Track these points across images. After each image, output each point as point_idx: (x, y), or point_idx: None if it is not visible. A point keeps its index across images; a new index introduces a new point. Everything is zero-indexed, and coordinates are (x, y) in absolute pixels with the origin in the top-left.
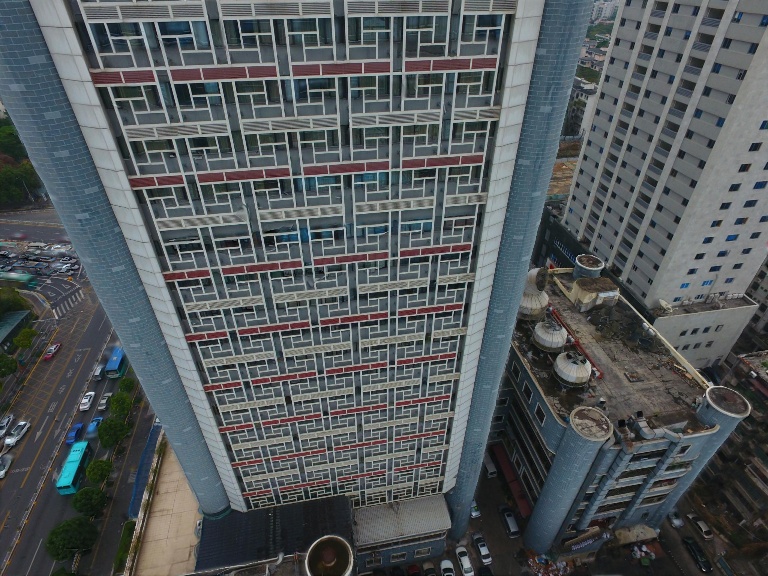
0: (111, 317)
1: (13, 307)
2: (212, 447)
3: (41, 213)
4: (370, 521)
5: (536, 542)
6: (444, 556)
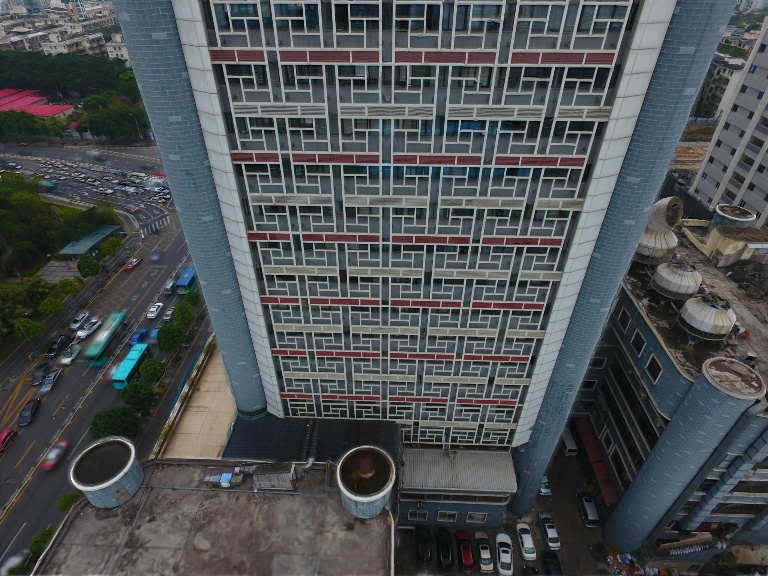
0: (149, 111)
1: (107, 221)
2: (252, 324)
3: (147, 150)
4: (420, 465)
5: (621, 536)
6: (501, 529)
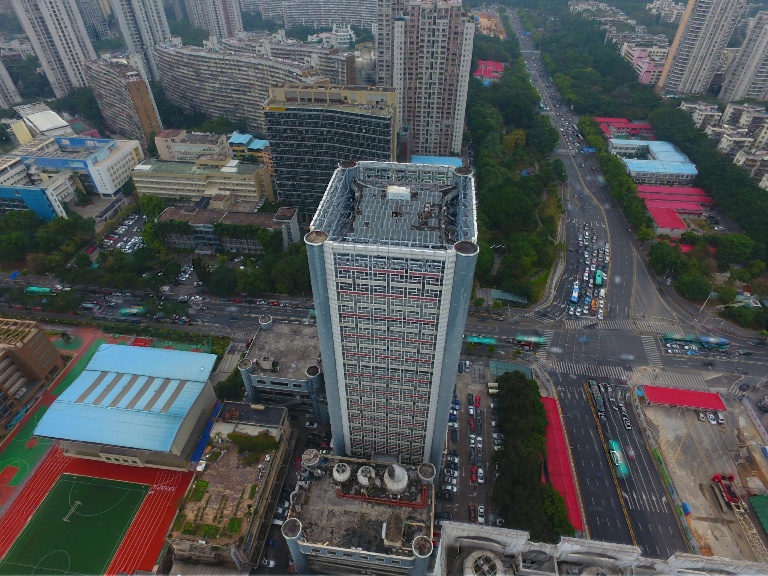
0: None
1: (529, 296)
2: None
3: (652, 286)
4: None
5: None
6: None
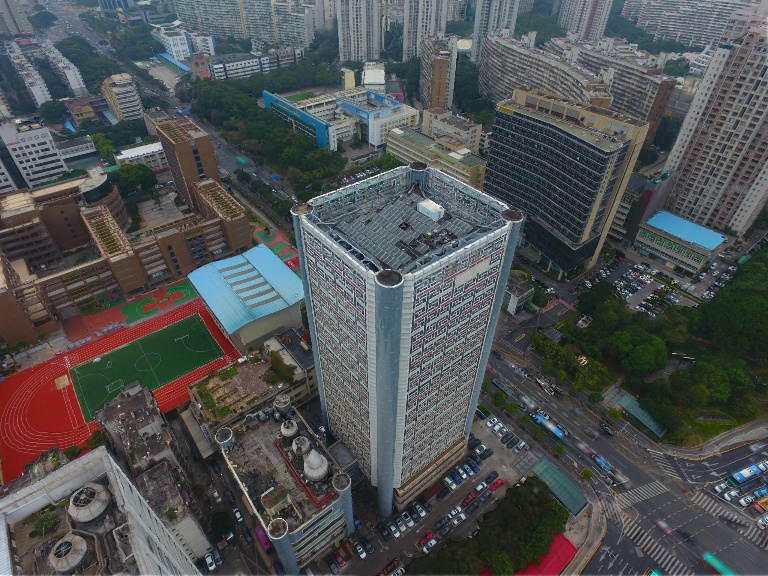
0: None
1: None
2: None
3: None
4: None
5: None
6: None
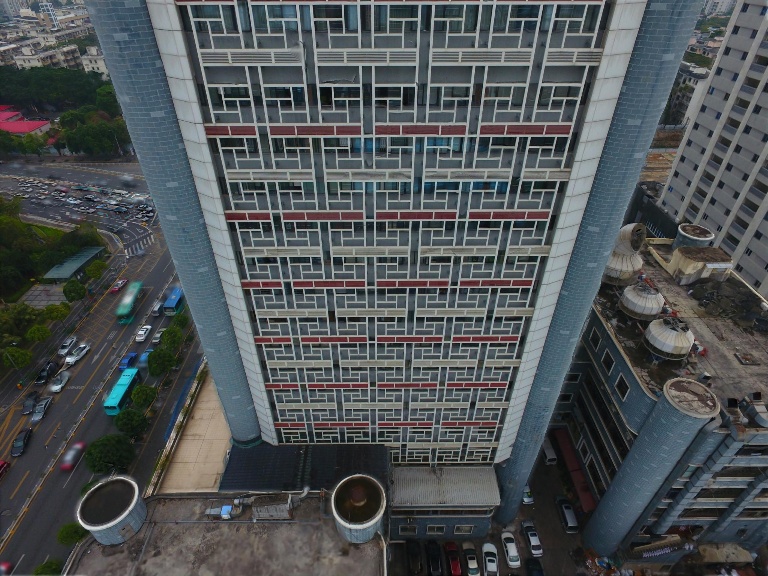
0: (148, 178)
1: (90, 242)
2: (246, 361)
3: (127, 166)
4: (409, 483)
5: (598, 541)
6: (487, 539)
